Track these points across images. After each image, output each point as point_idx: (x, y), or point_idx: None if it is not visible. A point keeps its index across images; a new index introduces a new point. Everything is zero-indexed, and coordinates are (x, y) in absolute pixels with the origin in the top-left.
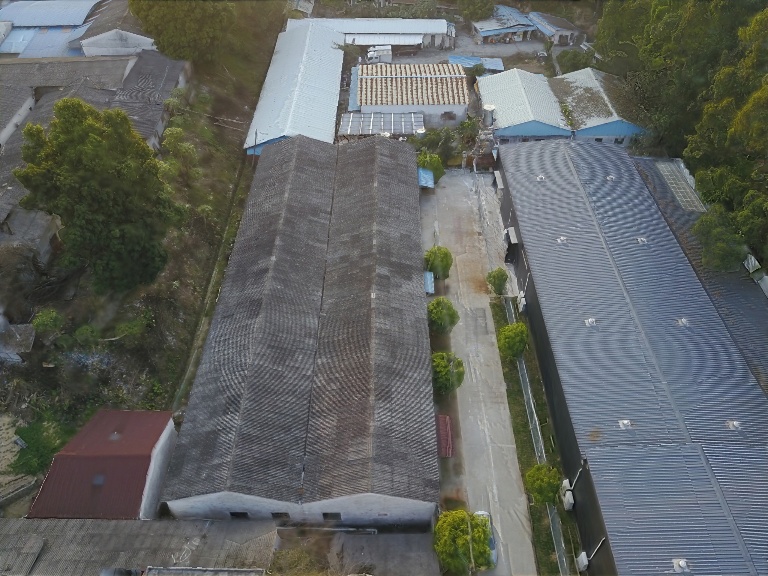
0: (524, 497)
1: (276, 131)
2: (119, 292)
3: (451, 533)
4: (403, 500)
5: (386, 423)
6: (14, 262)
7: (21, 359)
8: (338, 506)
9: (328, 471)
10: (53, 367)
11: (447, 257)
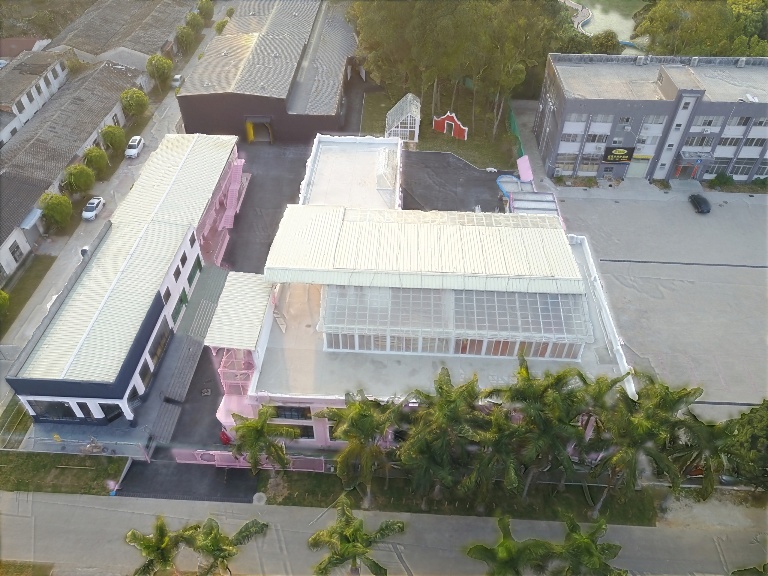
0: None
1: None
2: (36, 2)
3: (151, 58)
4: (138, 56)
5: (140, 35)
6: None
7: None
8: (113, 60)
9: None
10: (0, 21)
11: (208, 4)
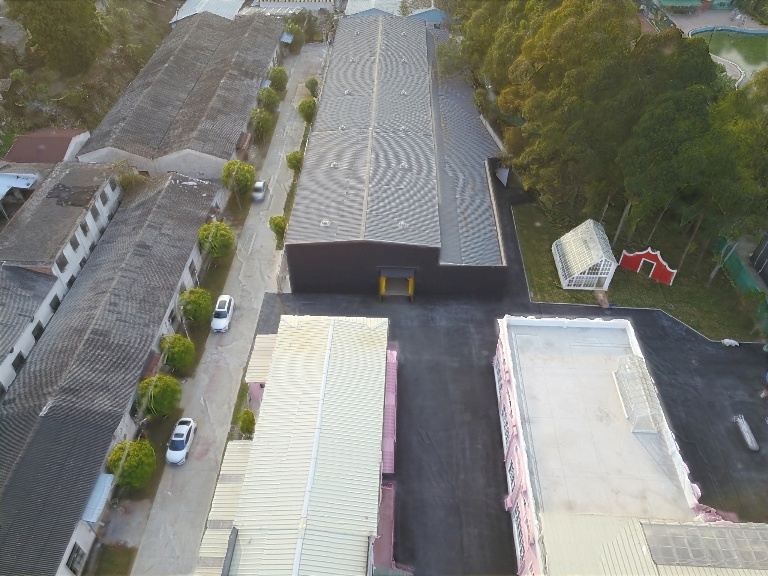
0: (291, 179)
1: (192, 12)
2: (66, 76)
3: (228, 166)
4: (209, 159)
5: (208, 128)
6: (1, 49)
7: (2, 98)
8: (174, 165)
9: (170, 146)
10: (21, 106)
11: (281, 72)
